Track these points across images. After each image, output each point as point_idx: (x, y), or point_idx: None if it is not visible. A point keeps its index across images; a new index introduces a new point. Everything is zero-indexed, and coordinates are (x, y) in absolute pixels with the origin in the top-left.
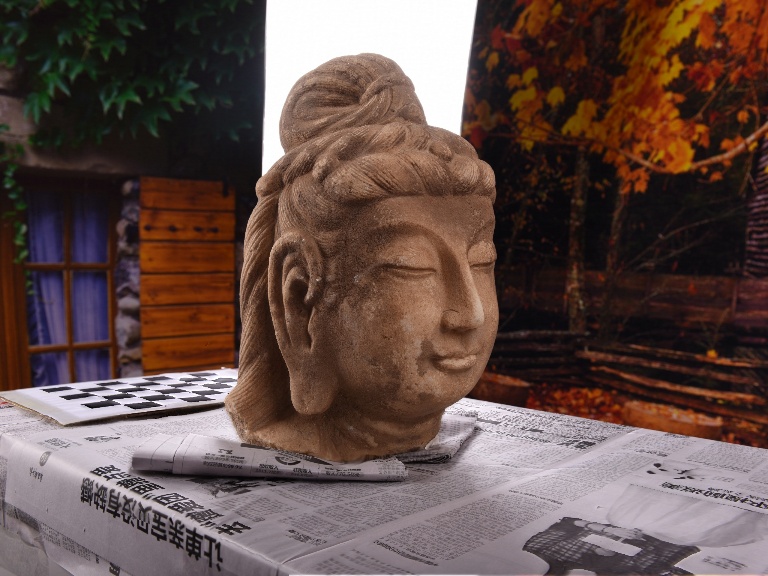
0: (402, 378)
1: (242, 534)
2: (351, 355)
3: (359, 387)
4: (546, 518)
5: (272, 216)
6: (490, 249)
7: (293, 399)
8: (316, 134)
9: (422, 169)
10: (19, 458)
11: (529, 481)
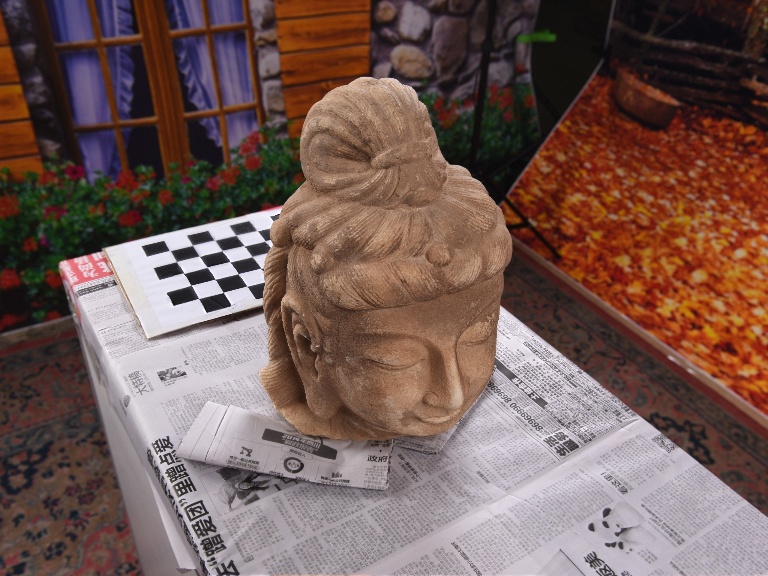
0: (388, 426)
1: None
2: (347, 398)
3: (356, 414)
4: None
5: (283, 267)
6: (486, 328)
7: (307, 401)
8: (325, 192)
9: (411, 286)
10: (113, 382)
11: (478, 525)
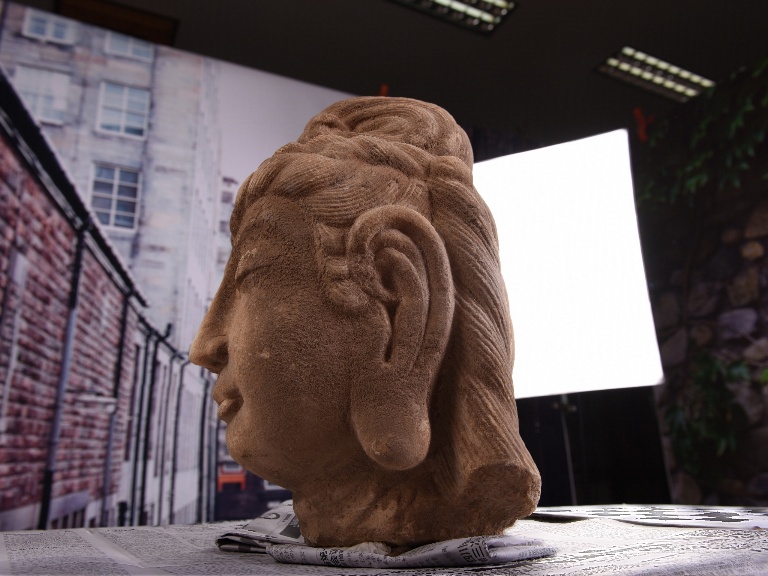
0: None
1: None
2: None
3: None
4: (1, 547)
5: None
6: None
7: None
8: None
9: None
10: None
11: None
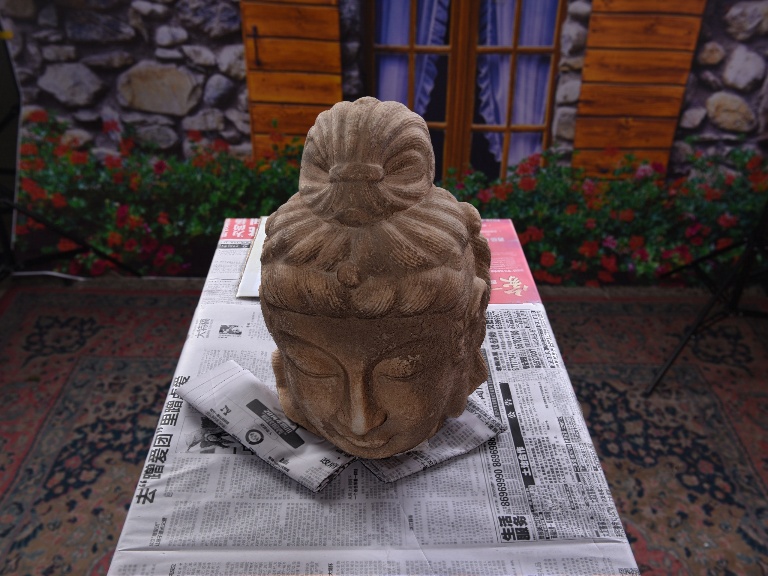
0: None
1: (142, 506)
2: None
3: None
4: None
5: None
6: (404, 366)
7: None
8: None
9: (314, 297)
10: None
11: (366, 561)
